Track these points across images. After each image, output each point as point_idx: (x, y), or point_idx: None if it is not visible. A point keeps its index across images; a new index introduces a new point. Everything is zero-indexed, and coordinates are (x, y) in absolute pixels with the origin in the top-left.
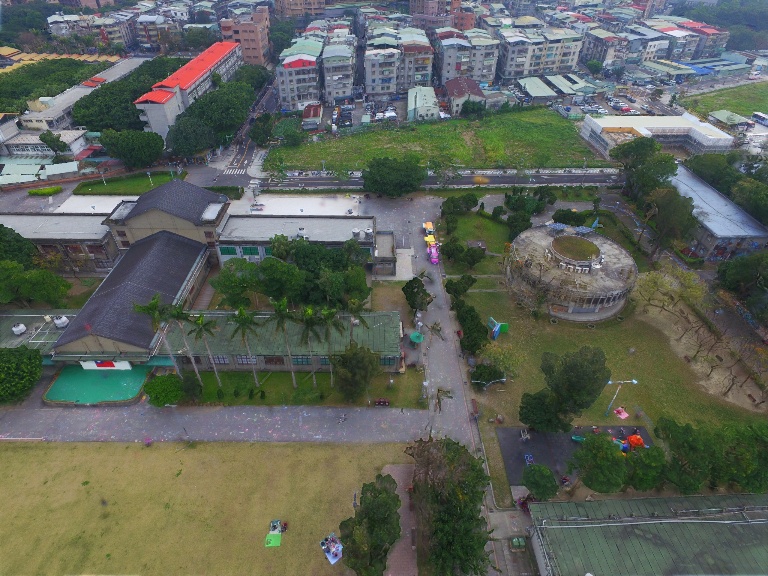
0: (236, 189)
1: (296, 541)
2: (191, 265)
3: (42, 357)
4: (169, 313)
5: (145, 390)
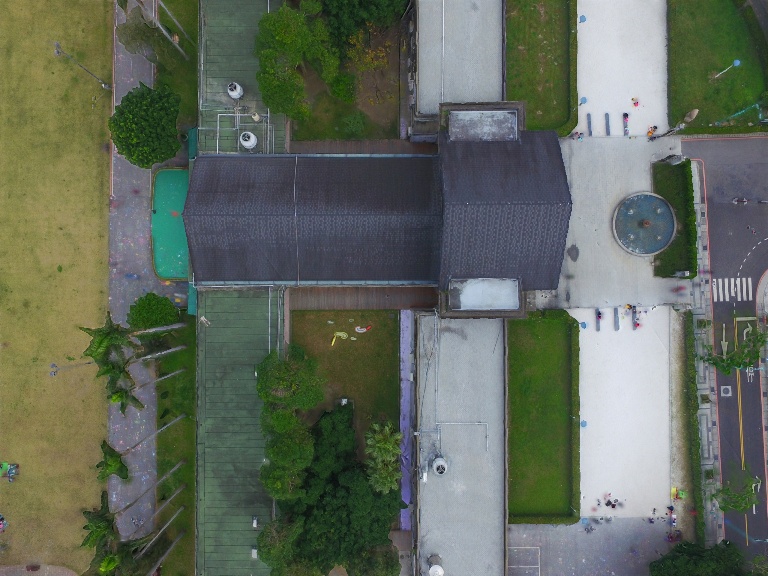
0: (690, 263)
1: (1, 491)
2: (379, 278)
3: (196, 144)
4: (108, 361)
5: (134, 302)
